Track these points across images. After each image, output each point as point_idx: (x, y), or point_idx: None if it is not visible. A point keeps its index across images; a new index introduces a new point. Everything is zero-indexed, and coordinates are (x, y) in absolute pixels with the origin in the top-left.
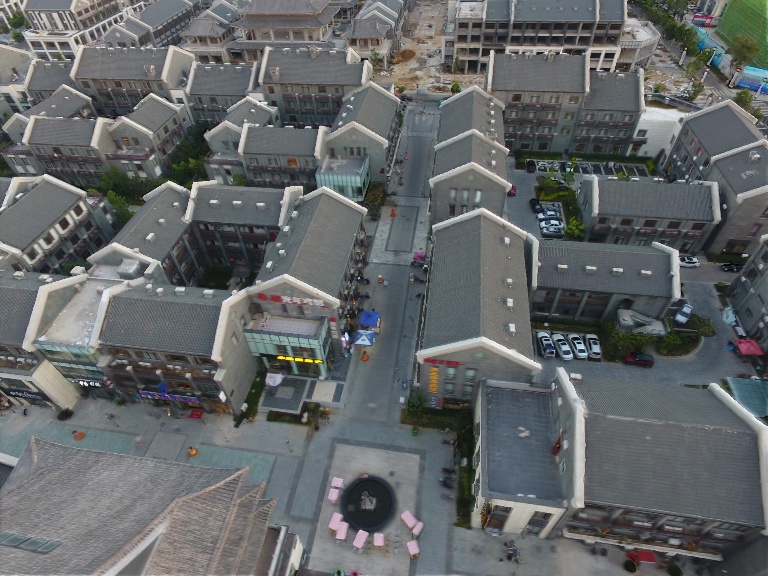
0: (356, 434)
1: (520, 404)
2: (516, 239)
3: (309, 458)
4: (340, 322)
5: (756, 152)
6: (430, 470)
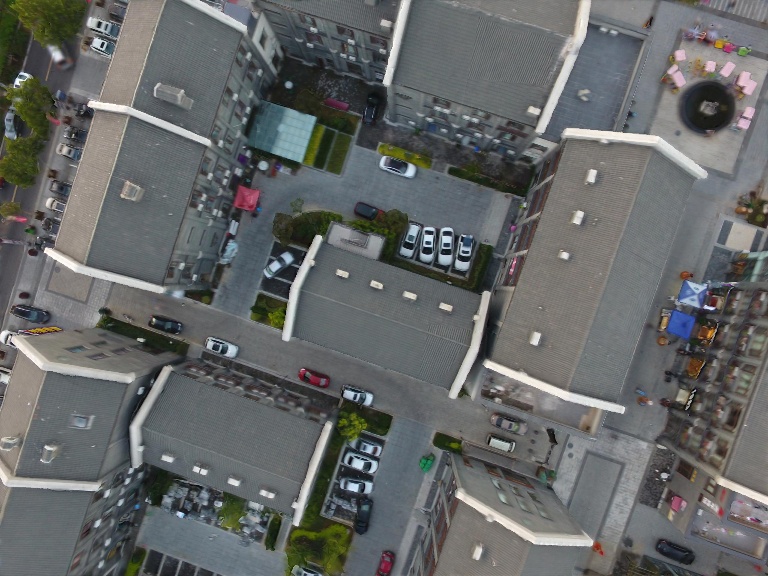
0: (709, 181)
1: (575, 126)
2: (507, 354)
3: (763, 163)
4: (744, 302)
5: (43, 458)
6: (639, 130)
